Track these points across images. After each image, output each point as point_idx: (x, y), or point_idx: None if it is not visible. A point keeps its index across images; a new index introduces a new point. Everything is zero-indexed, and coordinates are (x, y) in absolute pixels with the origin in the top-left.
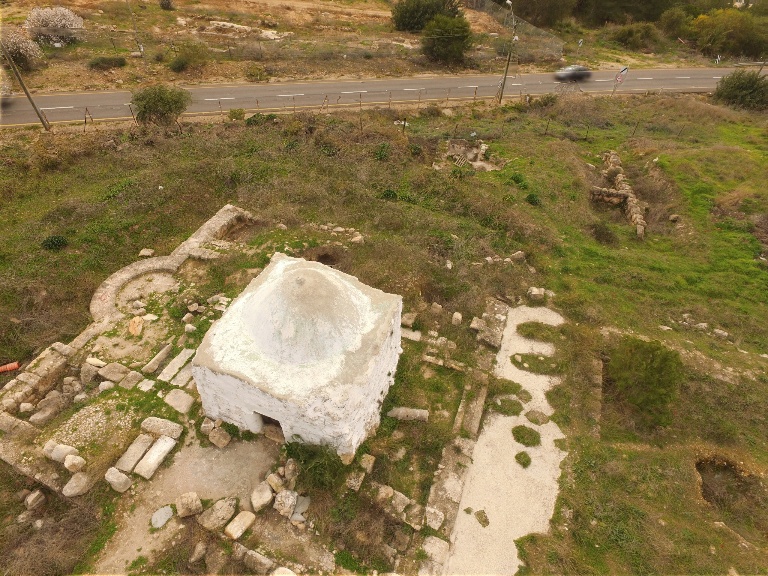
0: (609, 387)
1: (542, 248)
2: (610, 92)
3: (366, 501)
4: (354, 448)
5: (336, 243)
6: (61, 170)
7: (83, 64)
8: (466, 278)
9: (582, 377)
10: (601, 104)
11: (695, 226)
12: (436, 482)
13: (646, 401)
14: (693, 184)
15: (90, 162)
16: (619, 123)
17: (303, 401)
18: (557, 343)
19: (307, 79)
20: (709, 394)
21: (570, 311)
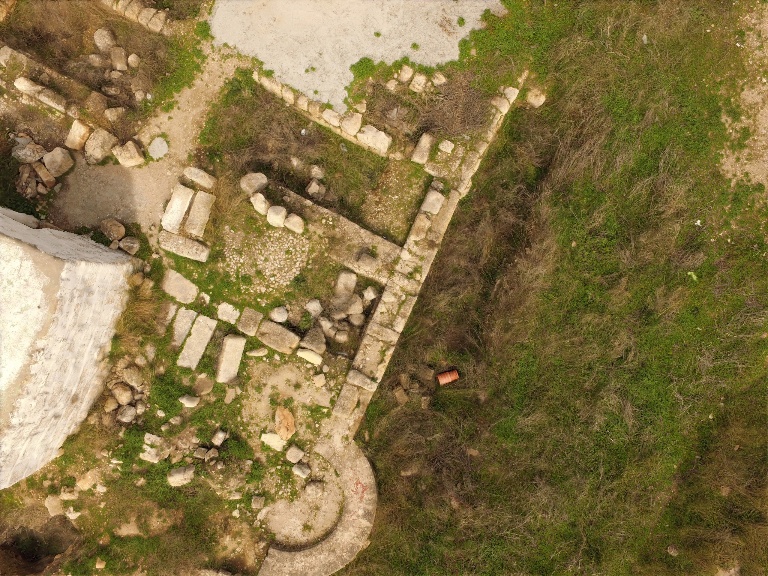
0: None
1: None
2: None
3: None
4: None
5: None
6: None
7: None
8: None
9: None
10: None
11: None
12: None
13: None
14: None
15: None
16: None
17: None
18: None
19: None
20: None
21: None
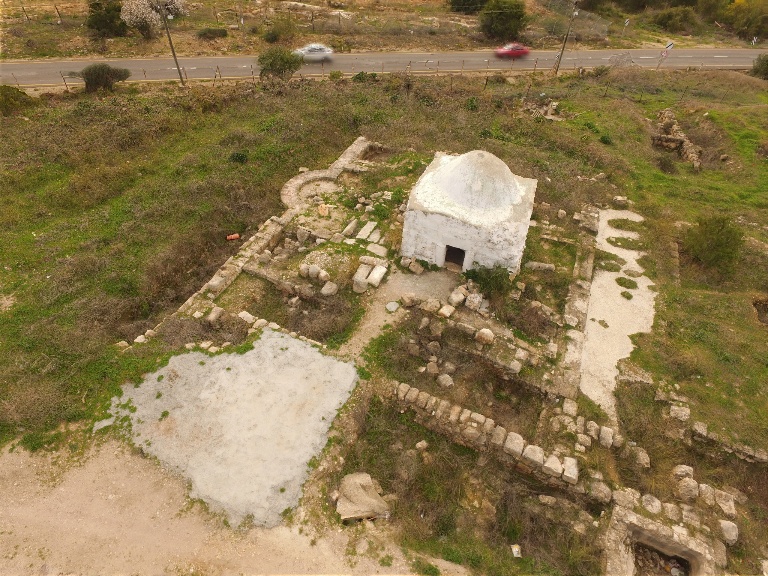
0: (683, 260)
1: (619, 173)
2: (654, 67)
3: (525, 306)
4: (515, 273)
5: None
6: (215, 111)
7: (191, 34)
8: (564, 188)
9: (663, 251)
10: (650, 75)
11: (743, 161)
12: (569, 302)
13: (717, 258)
14: (740, 131)
15: (236, 106)
16: (667, 90)
17: (491, 229)
18: (641, 232)
19: (382, 51)
20: (761, 264)
21: (648, 212)
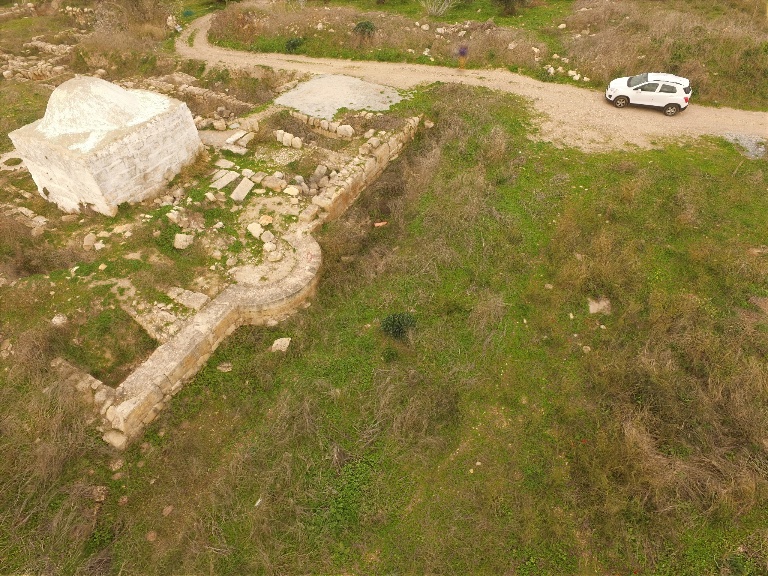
0: None
1: None
2: None
3: None
4: None
5: (5, 281)
6: None
7: None
8: None
9: None
10: None
11: None
12: None
13: None
14: None
15: None
16: None
17: None
18: None
19: None
20: None
21: None
